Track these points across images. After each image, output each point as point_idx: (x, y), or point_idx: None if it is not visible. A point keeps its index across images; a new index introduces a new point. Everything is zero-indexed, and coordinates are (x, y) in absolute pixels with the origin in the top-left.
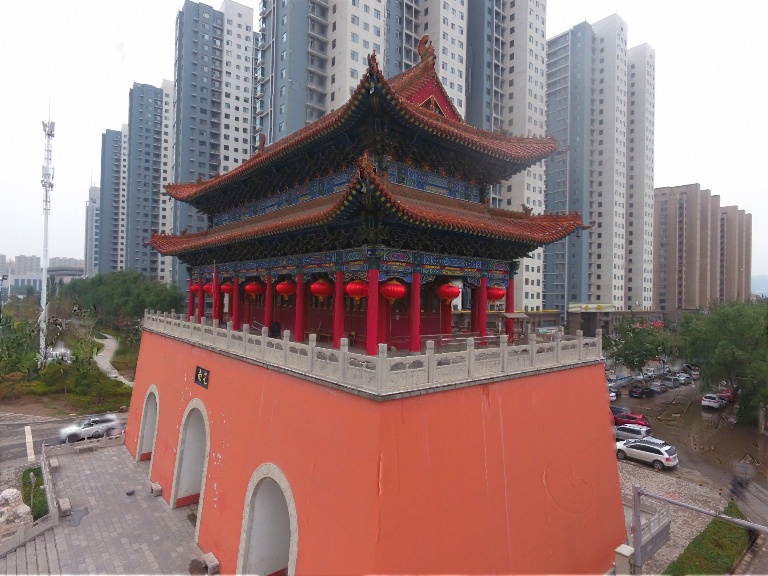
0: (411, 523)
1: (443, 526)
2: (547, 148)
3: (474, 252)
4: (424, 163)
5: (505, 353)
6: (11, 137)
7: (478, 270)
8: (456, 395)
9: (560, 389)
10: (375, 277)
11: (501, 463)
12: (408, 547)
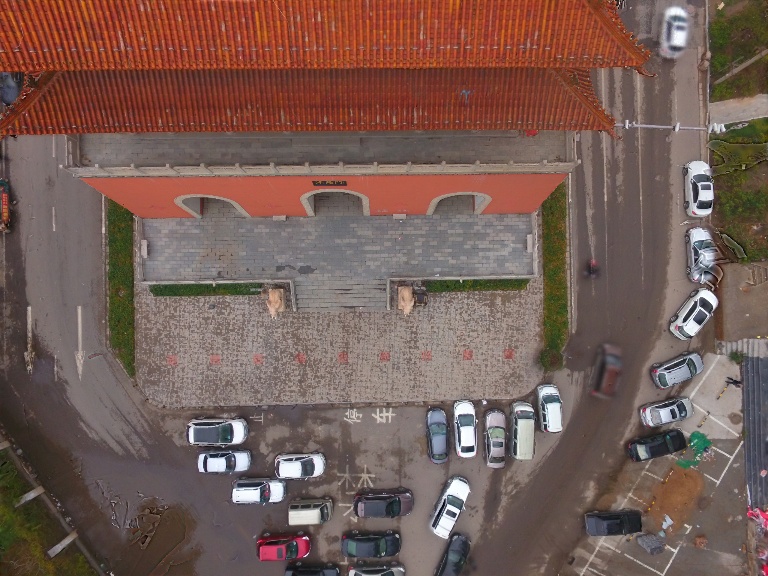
0: None
1: None
2: None
3: None
4: None
5: None
6: None
7: None
8: None
9: None
10: None
11: None
12: None
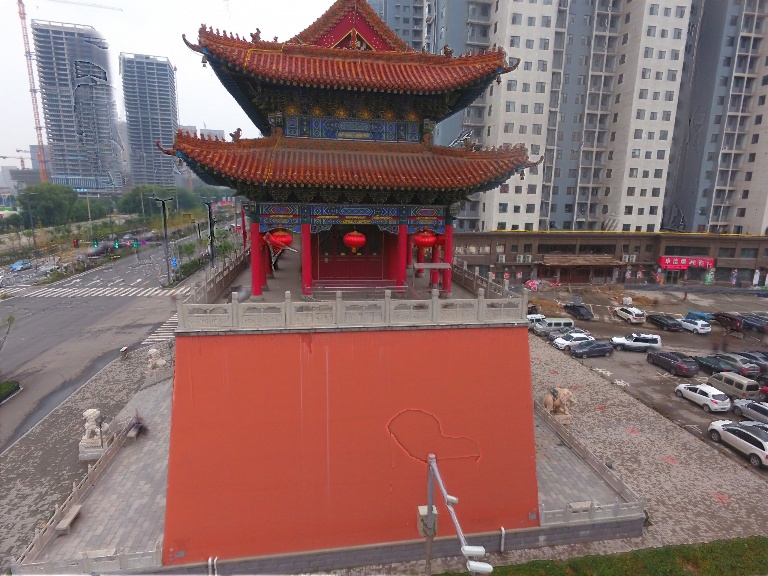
0: (208, 427)
1: (244, 437)
2: (488, 67)
3: (389, 199)
4: (336, 109)
5: (338, 307)
6: (174, 101)
7: (394, 217)
8: (265, 339)
9: (430, 348)
10: (253, 230)
11: (324, 403)
12: (204, 443)
